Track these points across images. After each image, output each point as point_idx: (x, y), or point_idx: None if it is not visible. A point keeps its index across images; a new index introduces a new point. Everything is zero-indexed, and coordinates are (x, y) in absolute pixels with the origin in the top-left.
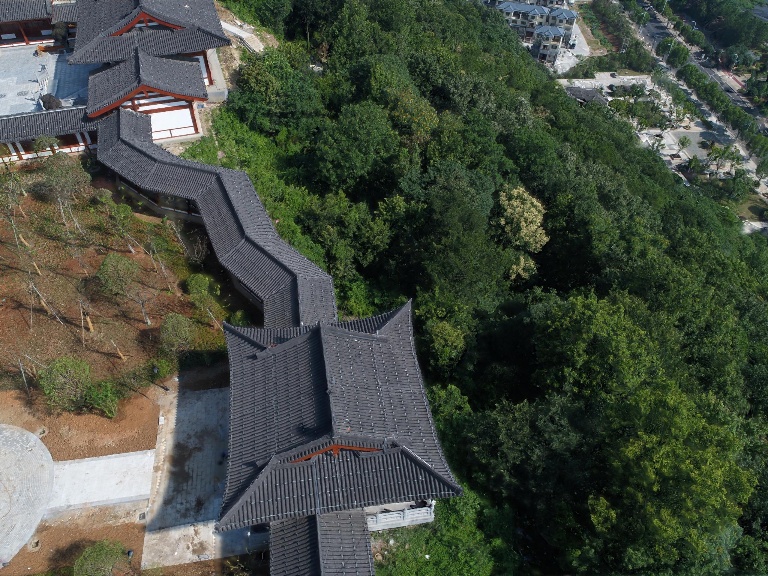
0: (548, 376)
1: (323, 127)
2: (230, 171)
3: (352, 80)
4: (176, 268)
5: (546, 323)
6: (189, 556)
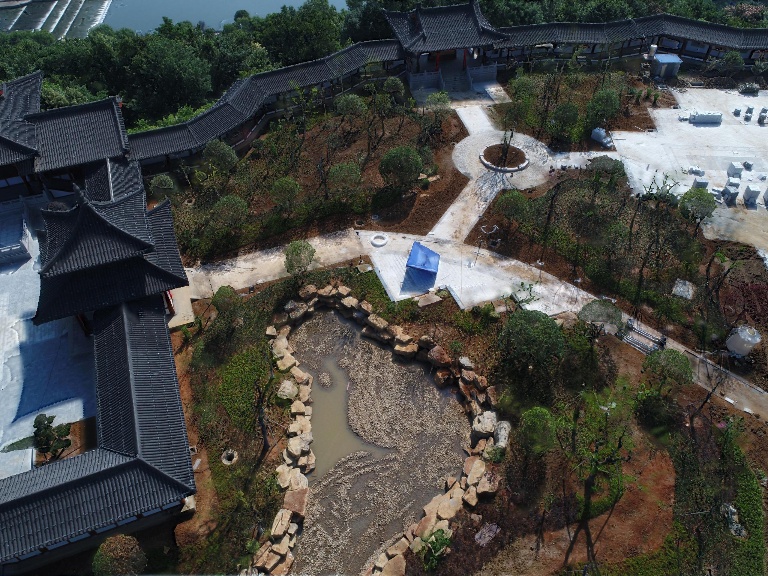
0: (405, 8)
1: (172, 64)
2: (236, 84)
3: (60, 79)
4: (321, 119)
5: (373, 8)
6: (503, 92)
